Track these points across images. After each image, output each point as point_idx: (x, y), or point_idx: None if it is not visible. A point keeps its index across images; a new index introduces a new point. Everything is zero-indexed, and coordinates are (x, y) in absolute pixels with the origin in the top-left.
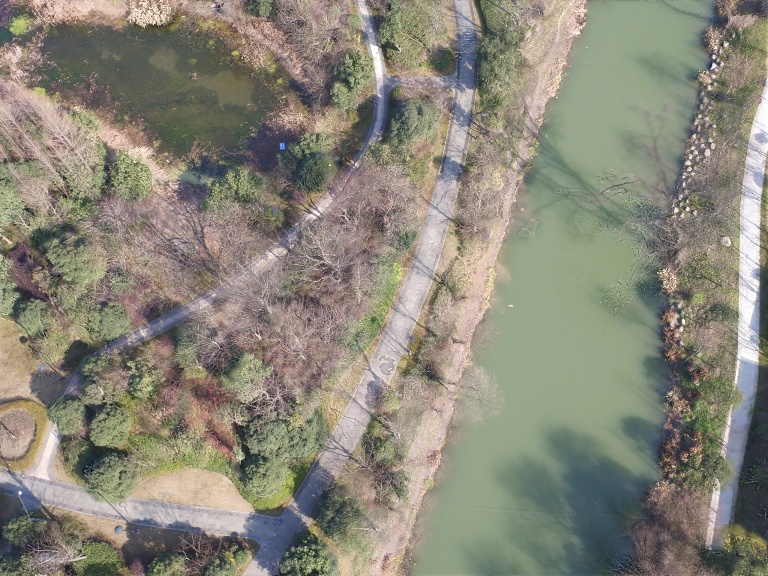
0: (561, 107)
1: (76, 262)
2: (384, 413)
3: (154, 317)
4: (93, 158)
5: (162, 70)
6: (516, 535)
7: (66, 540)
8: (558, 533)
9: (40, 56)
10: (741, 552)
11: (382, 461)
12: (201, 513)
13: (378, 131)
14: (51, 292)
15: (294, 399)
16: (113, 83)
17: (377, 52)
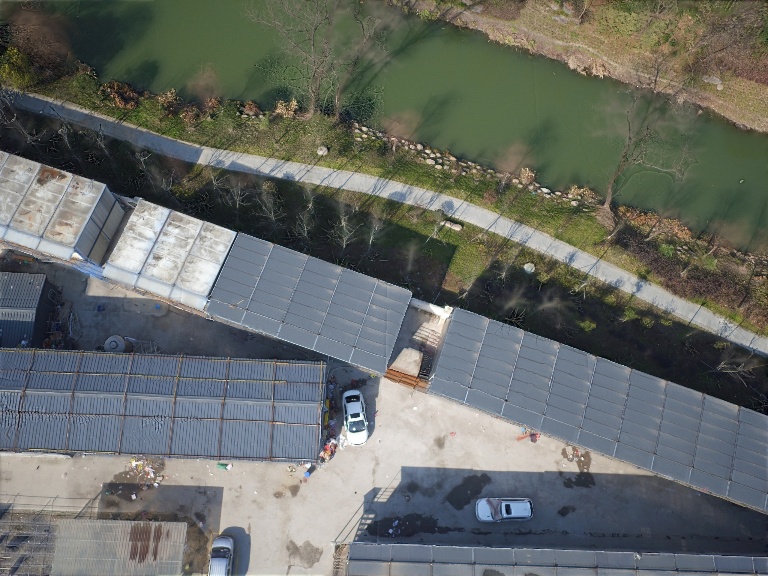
0: (478, 43)
1: None
2: None
3: None
4: None
5: None
6: None
7: None
8: (64, 2)
9: None
10: (4, 57)
11: None
12: None
13: None
14: None
15: None
16: None
17: None
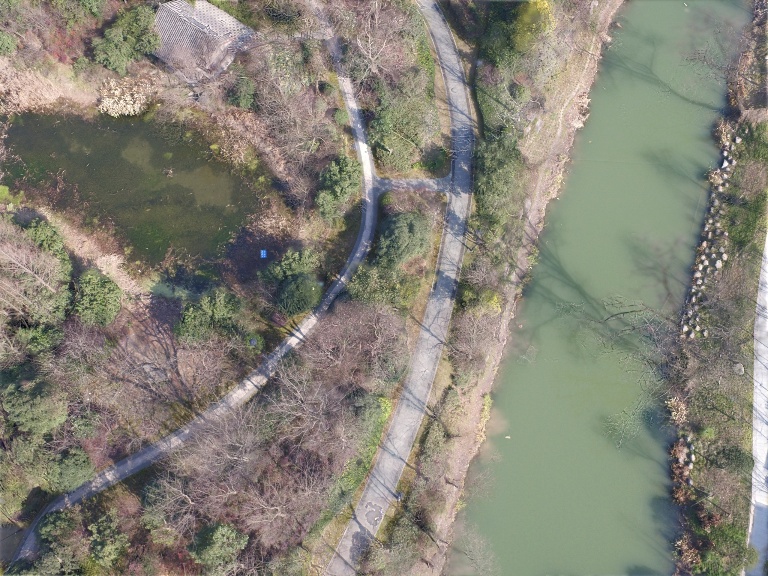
0: (563, 209)
1: (32, 413)
2: (370, 572)
3: (121, 457)
4: (57, 275)
5: (135, 165)
6: None
7: None
8: None
9: (4, 149)
10: None
11: None
12: None
13: (366, 241)
14: (6, 439)
15: (270, 574)
16: (82, 180)
17: (366, 151)
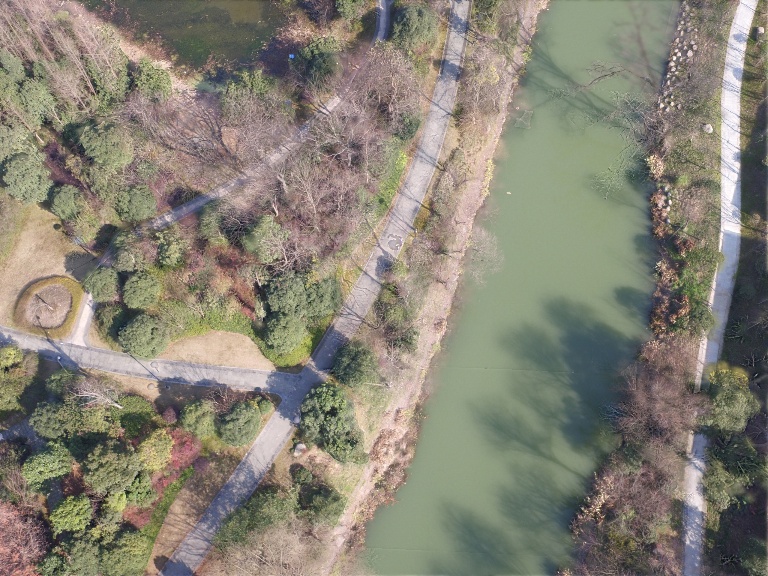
0: (552, 18)
1: (106, 144)
2: (393, 281)
3: (177, 204)
4: (117, 65)
5: None
6: (518, 391)
7: (104, 391)
8: (557, 389)
9: None
10: (725, 383)
11: (392, 322)
12: (226, 371)
13: (381, 39)
14: (83, 177)
15: (310, 258)
16: (132, 6)
17: None
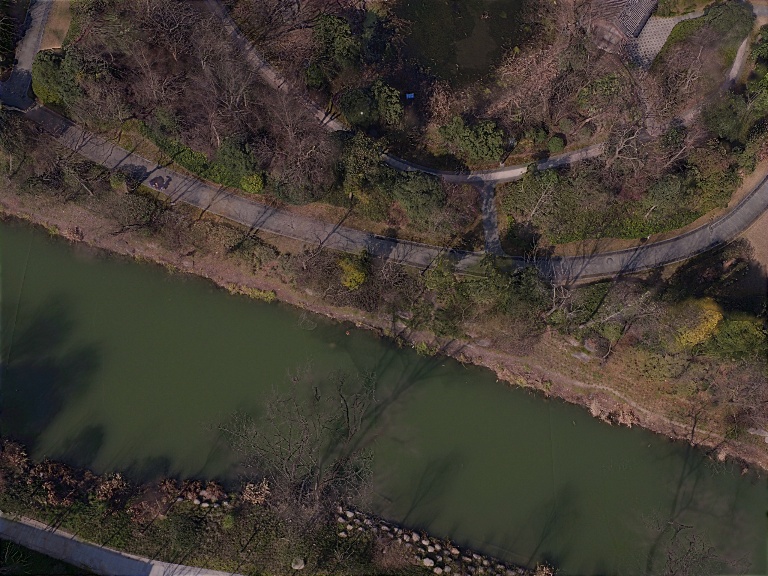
0: (484, 385)
1: None
2: None
3: None
4: None
5: None
6: None
7: None
8: None
9: None
10: None
11: (63, 173)
12: (37, 36)
13: None
14: None
15: None
16: None
17: (523, 172)
